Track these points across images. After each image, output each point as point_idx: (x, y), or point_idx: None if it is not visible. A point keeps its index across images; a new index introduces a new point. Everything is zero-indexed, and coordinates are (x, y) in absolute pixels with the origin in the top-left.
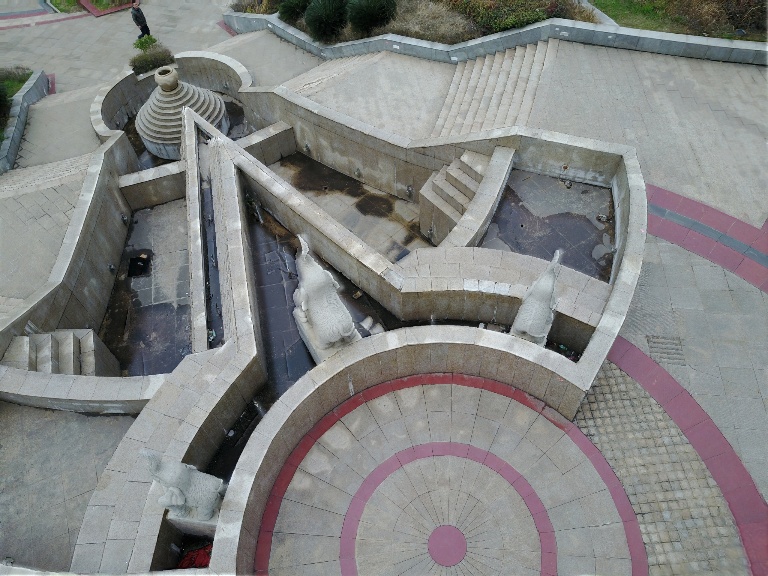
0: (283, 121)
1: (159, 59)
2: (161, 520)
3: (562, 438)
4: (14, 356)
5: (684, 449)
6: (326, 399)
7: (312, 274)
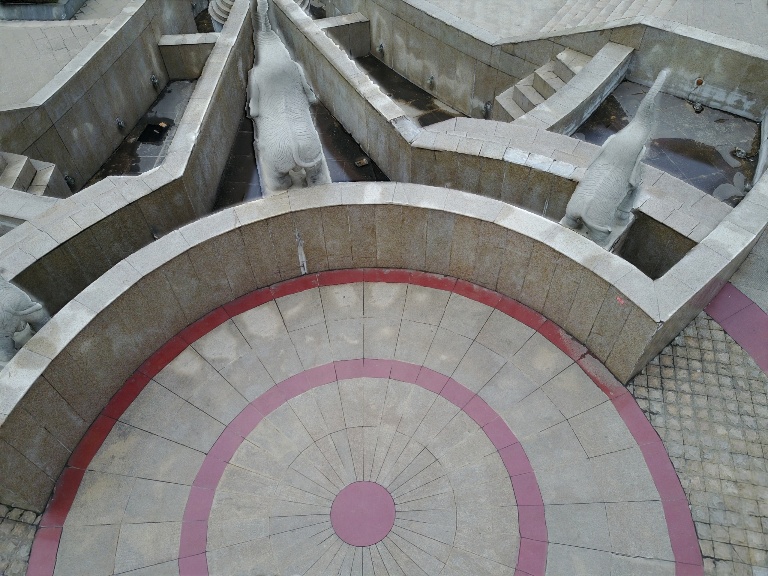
0: (361, 13)
1: None
2: None
3: (602, 405)
4: None
5: None
6: (258, 260)
7: (269, 53)
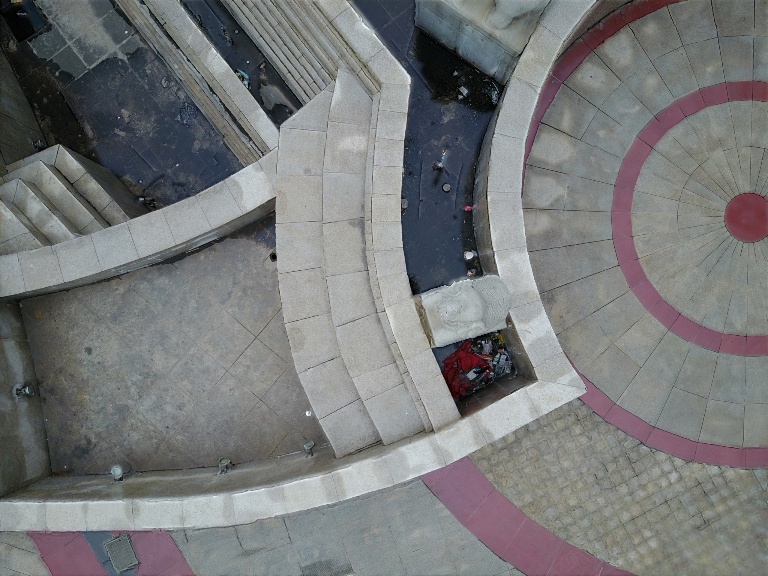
0: None
1: None
2: (433, 355)
3: None
4: (1, 233)
5: None
6: None
7: None
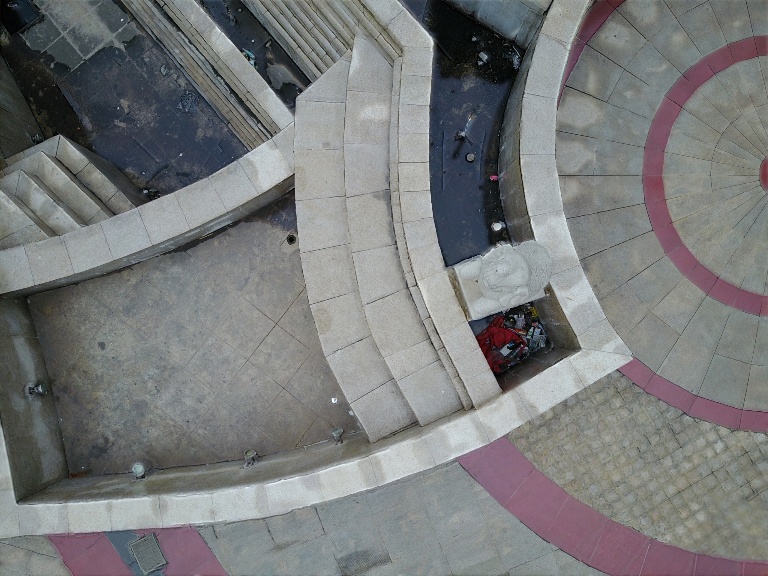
0: None
1: None
2: (470, 328)
3: None
4: (5, 227)
5: None
6: None
7: None
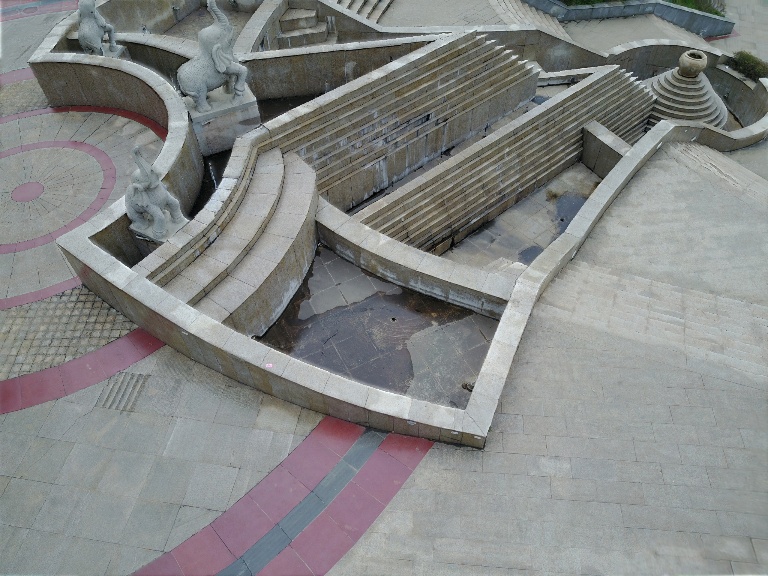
0: None
1: (755, 70)
2: None
3: (71, 274)
4: (299, 13)
5: (4, 371)
6: None
7: (205, 30)
